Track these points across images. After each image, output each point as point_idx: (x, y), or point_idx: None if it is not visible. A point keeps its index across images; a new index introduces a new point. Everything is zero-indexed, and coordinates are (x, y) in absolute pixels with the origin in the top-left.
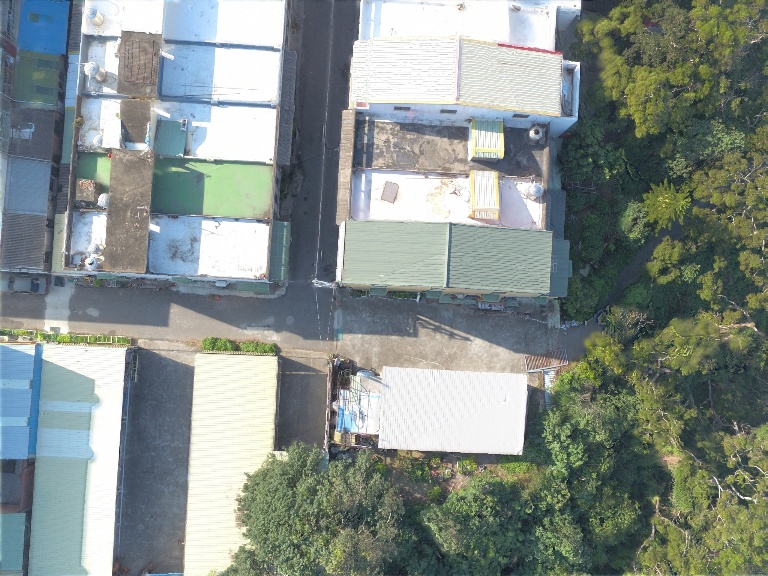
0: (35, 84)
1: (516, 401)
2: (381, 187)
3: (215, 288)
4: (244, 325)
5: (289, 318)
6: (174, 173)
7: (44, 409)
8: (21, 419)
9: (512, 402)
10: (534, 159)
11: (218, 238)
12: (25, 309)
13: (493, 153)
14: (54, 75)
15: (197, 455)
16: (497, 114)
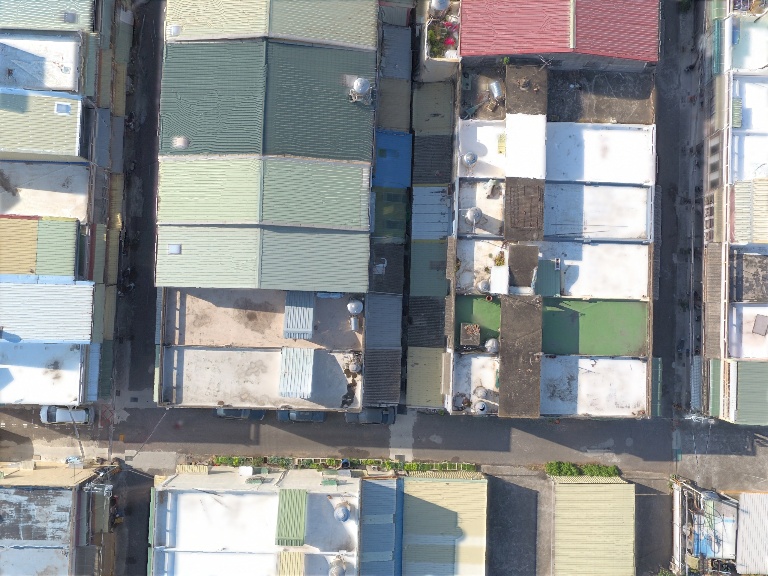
0: (386, 219)
1: None
2: (752, 320)
3: None
4: (584, 448)
5: (628, 440)
6: (549, 312)
7: (408, 543)
8: (386, 553)
9: None
10: None
11: (595, 376)
12: (370, 438)
13: None
14: (402, 208)
15: None
16: None
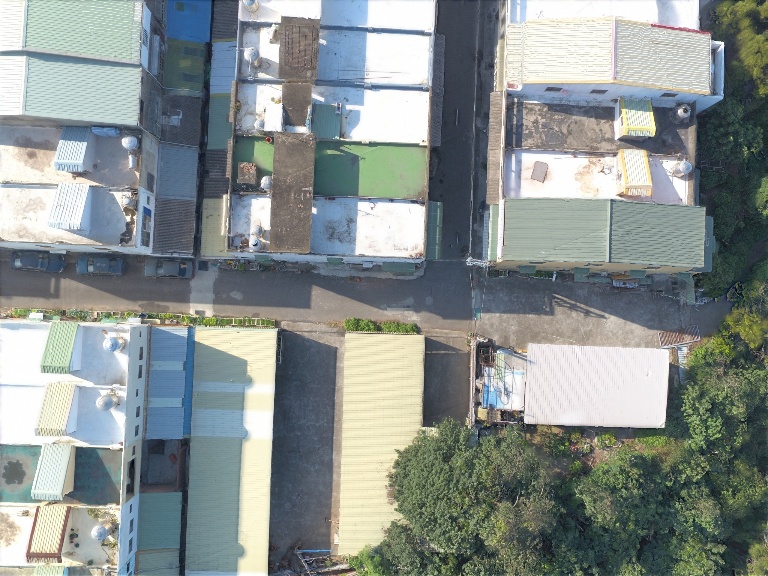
0: (182, 71)
1: (658, 375)
2: (531, 167)
3: (355, 270)
4: (384, 306)
5: (428, 298)
6: (329, 156)
7: (198, 390)
8: (176, 400)
9: (654, 376)
10: (679, 137)
11: (374, 219)
12: (170, 293)
13: (645, 131)
14: (199, 62)
15: (349, 433)
16: (647, 93)
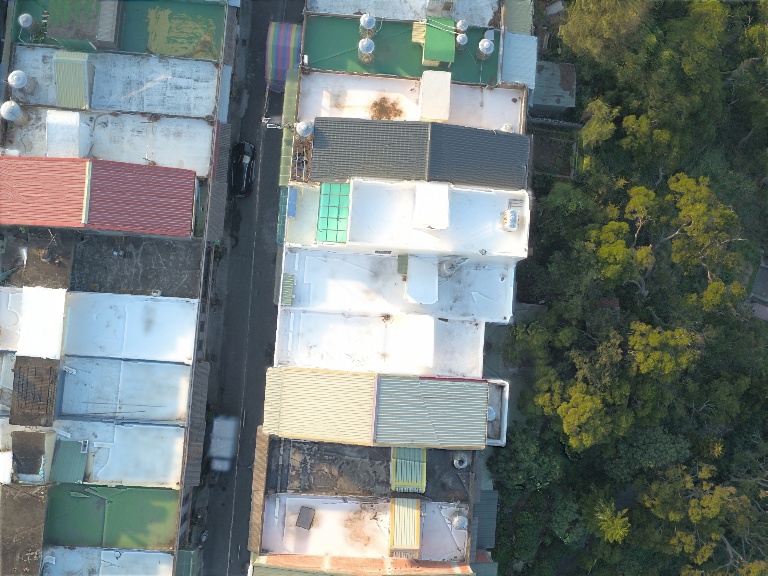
0: None
1: None
2: (296, 512)
3: None
4: None
5: None
6: (73, 498)
7: None
8: None
9: None
10: (460, 481)
11: (118, 570)
12: None
13: (414, 488)
14: None
15: None
16: None
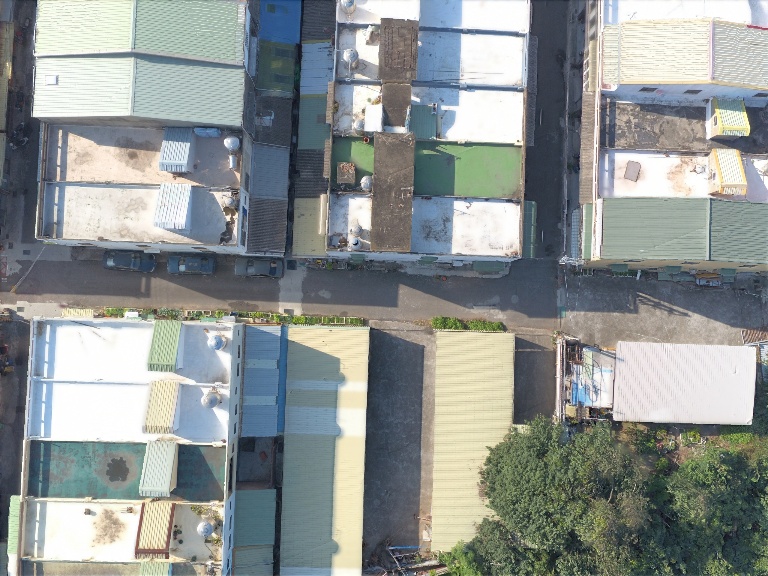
0: (273, 73)
1: (746, 373)
2: (624, 166)
3: (441, 269)
4: (470, 304)
5: (514, 297)
6: (425, 156)
7: (291, 388)
8: (270, 398)
9: (742, 374)
10: None
11: (470, 218)
12: (260, 292)
13: (740, 131)
14: (290, 64)
15: (440, 430)
16: (740, 93)
